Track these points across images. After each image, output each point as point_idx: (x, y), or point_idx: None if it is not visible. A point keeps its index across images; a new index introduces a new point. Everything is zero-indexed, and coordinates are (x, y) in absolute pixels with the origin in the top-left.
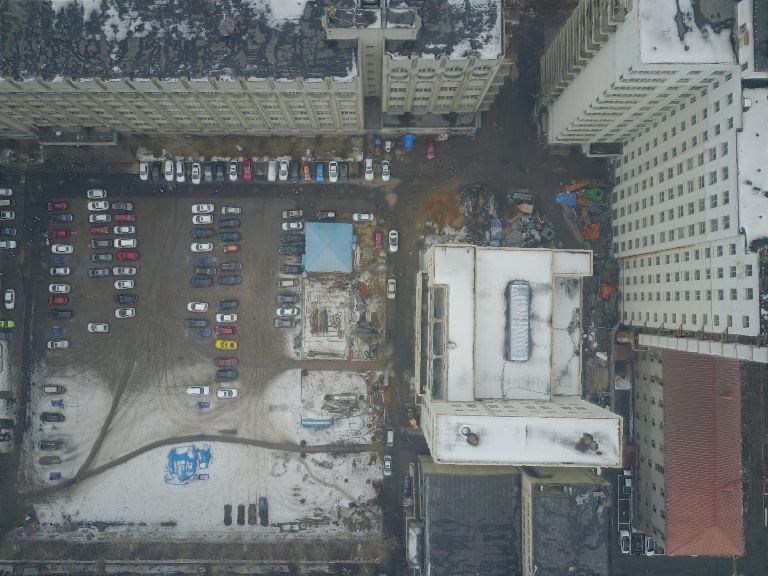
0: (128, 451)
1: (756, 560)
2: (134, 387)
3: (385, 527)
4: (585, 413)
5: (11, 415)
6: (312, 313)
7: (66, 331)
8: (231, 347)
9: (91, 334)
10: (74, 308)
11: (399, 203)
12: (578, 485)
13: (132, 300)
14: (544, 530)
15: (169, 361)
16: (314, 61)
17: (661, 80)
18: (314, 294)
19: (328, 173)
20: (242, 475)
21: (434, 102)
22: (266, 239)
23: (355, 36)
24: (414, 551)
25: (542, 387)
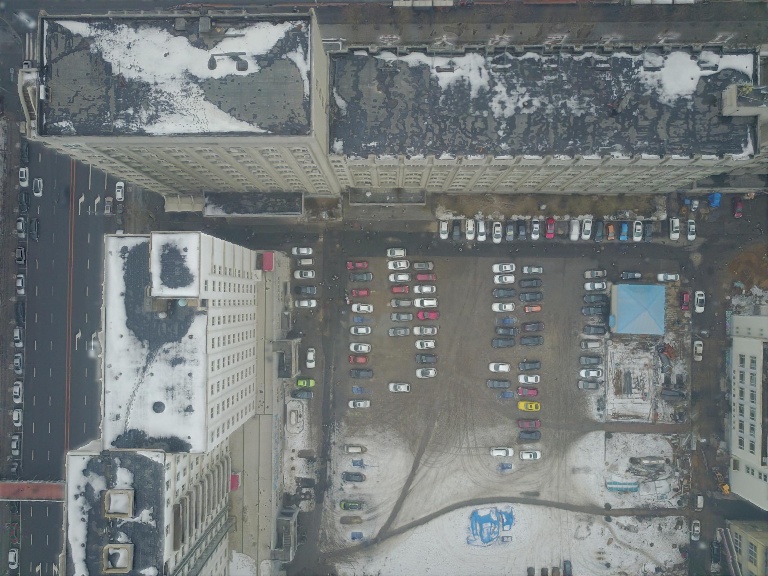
0: (430, 512)
1: None
2: (435, 447)
3: None
4: None
5: (312, 474)
6: (615, 374)
7: None
8: (535, 409)
9: (391, 394)
10: (374, 367)
11: (704, 263)
12: None
13: (435, 360)
14: None
15: (470, 422)
16: (707, 137)
17: None
18: (617, 355)
19: (632, 232)
20: (545, 537)
21: (766, 165)
22: (567, 299)
23: (756, 113)
24: None
25: None
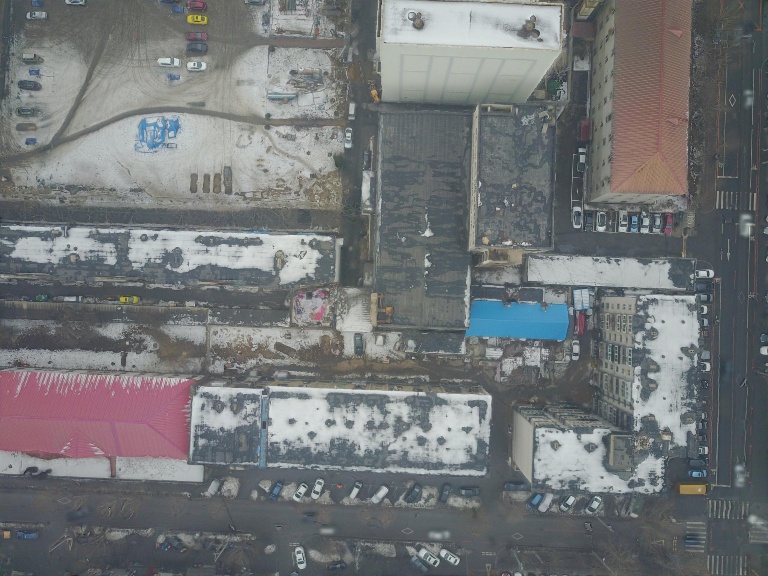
0: (101, 120)
1: (706, 241)
2: (108, 59)
3: (344, 198)
4: None
5: None
6: None
7: (45, 3)
8: (201, 20)
9: (68, 8)
10: None
11: None
12: (524, 105)
13: None
14: (490, 149)
15: (142, 35)
16: None
17: None
18: None
19: None
20: (209, 146)
21: None
22: None
23: None
24: (367, 193)
25: None
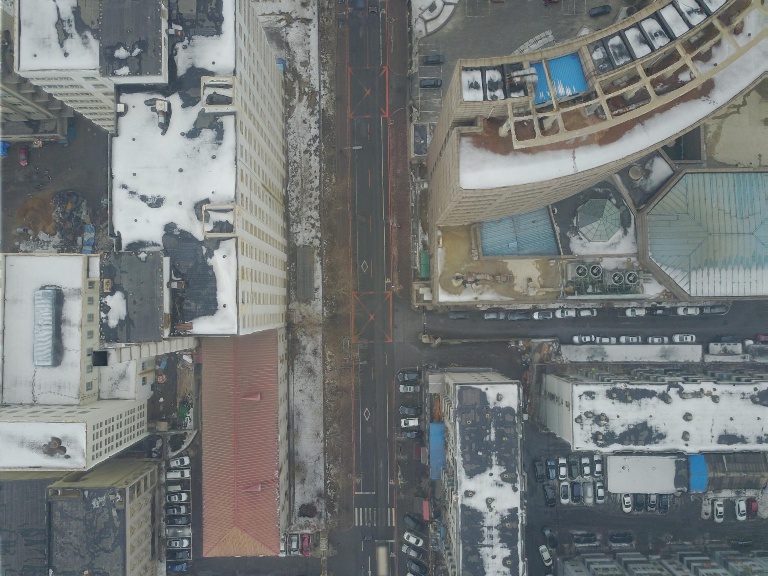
0: None
1: (346, 559)
2: None
3: None
4: (64, 417)
5: None
6: None
7: None
8: None
9: None
10: None
11: None
12: (92, 488)
13: None
14: (61, 534)
15: None
16: None
17: (80, 86)
18: None
19: None
20: None
21: None
22: None
23: None
24: None
25: (73, 391)
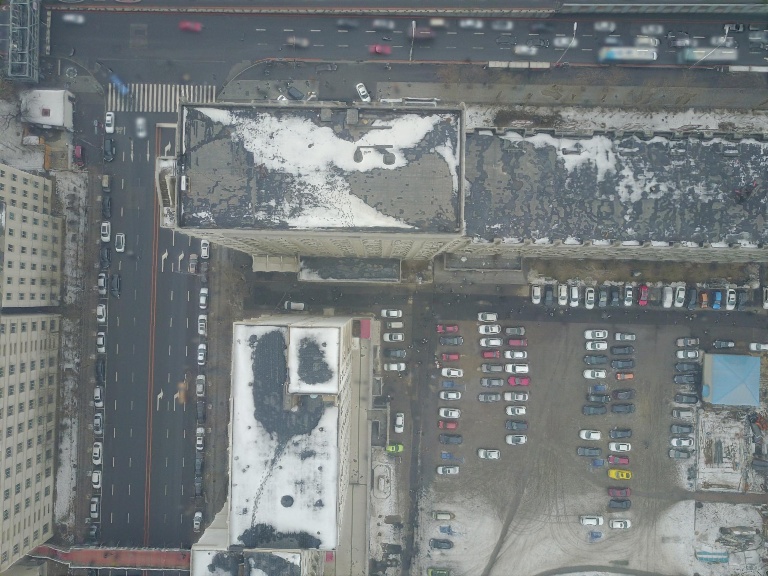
0: None
1: None
2: (524, 515)
3: None
4: None
5: (398, 540)
6: (706, 443)
7: (456, 456)
8: (626, 477)
9: (480, 460)
10: (463, 433)
11: None
12: None
13: (526, 427)
14: None
15: (559, 489)
16: None
17: None
18: (708, 424)
19: (725, 301)
20: None
21: None
22: (659, 366)
23: None
24: None
25: None
